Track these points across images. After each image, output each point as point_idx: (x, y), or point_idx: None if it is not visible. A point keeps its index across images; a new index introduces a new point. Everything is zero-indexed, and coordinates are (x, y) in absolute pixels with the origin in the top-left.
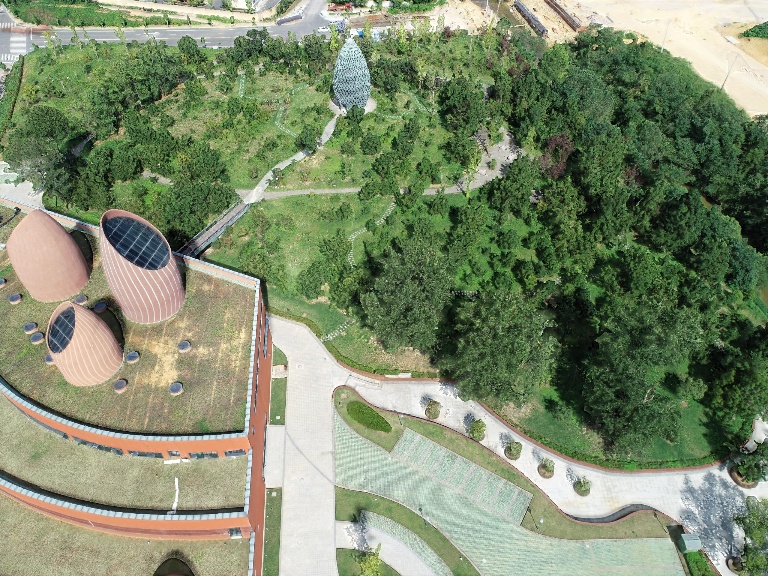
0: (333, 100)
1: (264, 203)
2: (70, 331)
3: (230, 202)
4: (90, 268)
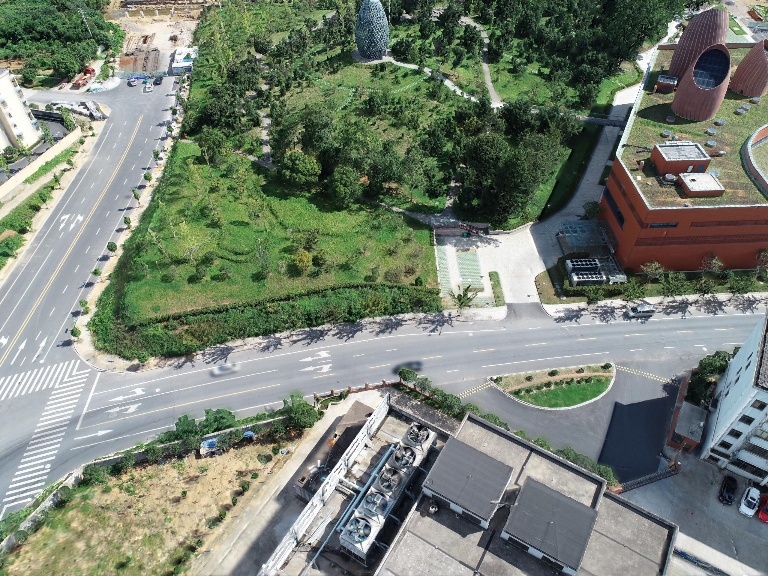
0: (362, 62)
1: (507, 100)
2: (767, 55)
3: None
4: None
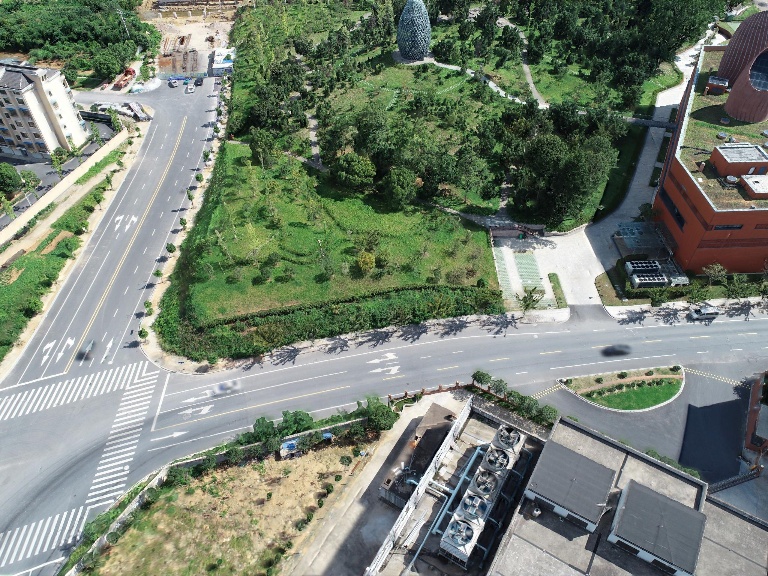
0: (404, 64)
1: None
2: None
3: None
4: None
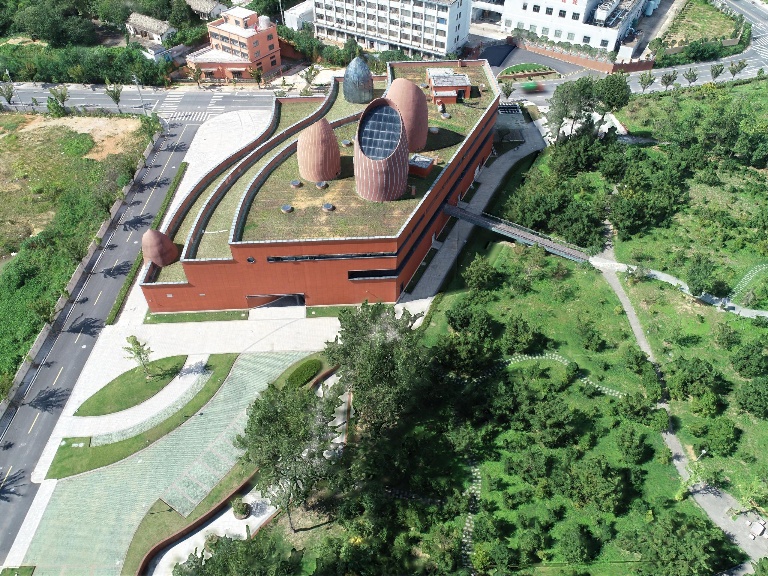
0: None
1: (595, 273)
2: None
3: (588, 247)
4: (420, 151)
